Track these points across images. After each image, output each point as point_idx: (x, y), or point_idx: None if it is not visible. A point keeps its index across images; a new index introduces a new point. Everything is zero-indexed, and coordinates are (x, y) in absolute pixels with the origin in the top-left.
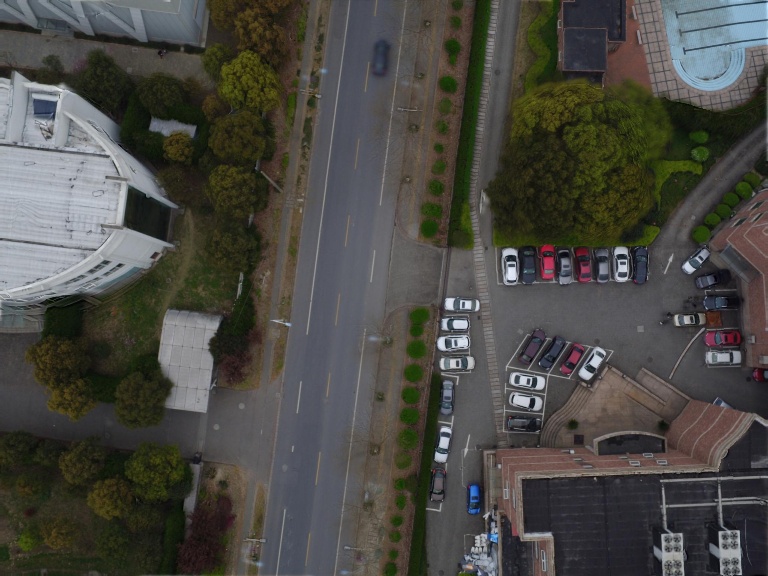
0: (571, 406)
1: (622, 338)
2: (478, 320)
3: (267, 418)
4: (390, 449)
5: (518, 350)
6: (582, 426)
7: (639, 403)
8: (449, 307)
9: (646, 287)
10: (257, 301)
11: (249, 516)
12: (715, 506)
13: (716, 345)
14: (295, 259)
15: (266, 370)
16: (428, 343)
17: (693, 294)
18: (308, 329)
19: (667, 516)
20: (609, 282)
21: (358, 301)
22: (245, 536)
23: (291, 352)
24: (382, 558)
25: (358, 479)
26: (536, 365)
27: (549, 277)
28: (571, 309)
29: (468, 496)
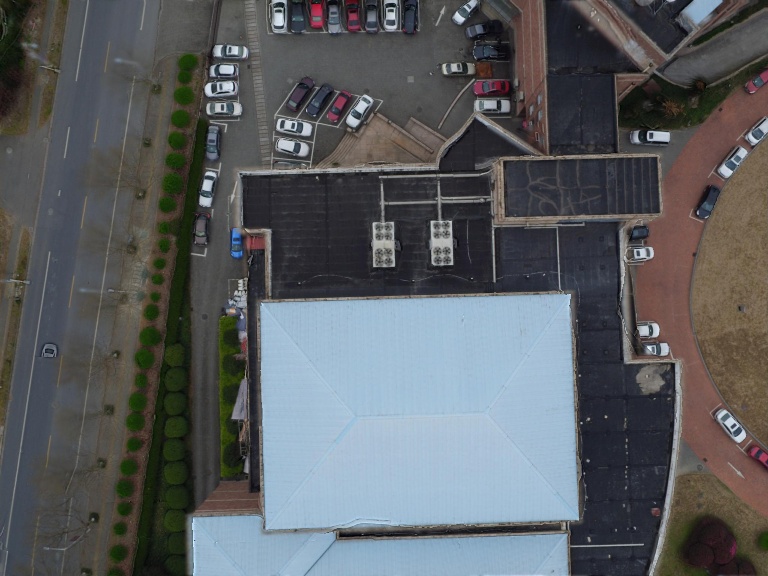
0: (338, 153)
1: (392, 88)
2: (248, 69)
3: (34, 162)
4: (156, 194)
5: (287, 99)
6: (342, 166)
7: (405, 150)
8: (217, 54)
9: (417, 38)
10: (26, 47)
11: (13, 257)
12: (435, 204)
13: (483, 93)
14: (66, 7)
15: (34, 115)
16: (197, 91)
17: (464, 46)
18: (77, 76)
19: (386, 212)
20: (380, 33)
21: (127, 48)
22: (9, 277)
23: (60, 98)
24: (145, 300)
25: (123, 223)
26: (304, 113)
27: (317, 25)
28: (341, 59)
29: (230, 238)
